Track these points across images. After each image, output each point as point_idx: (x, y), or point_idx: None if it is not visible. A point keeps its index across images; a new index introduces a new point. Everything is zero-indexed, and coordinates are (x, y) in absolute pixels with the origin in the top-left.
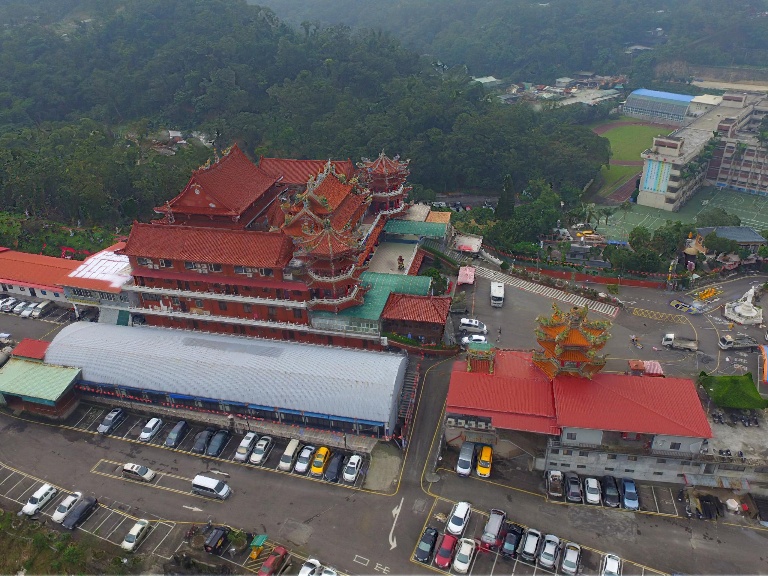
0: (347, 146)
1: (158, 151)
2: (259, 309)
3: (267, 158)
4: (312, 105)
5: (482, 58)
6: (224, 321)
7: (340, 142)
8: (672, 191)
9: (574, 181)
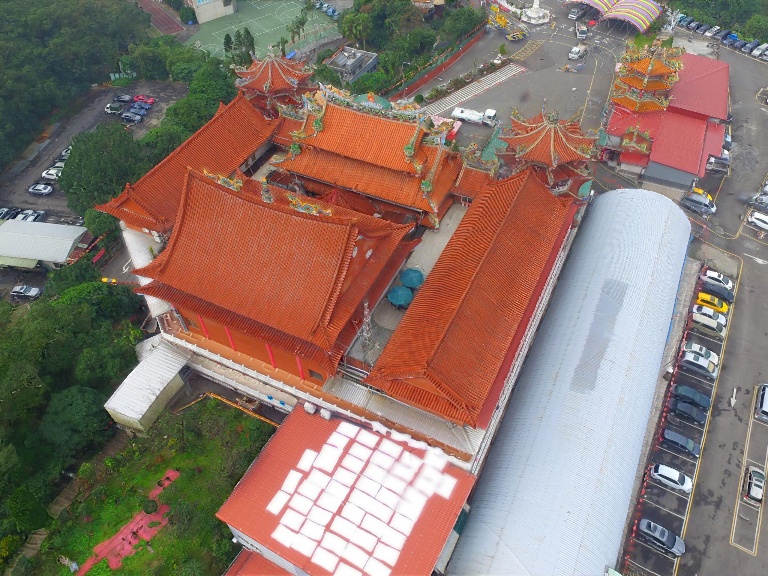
0: None
1: None
2: None
3: (137, 183)
4: None
5: None
6: None
7: None
8: None
9: None
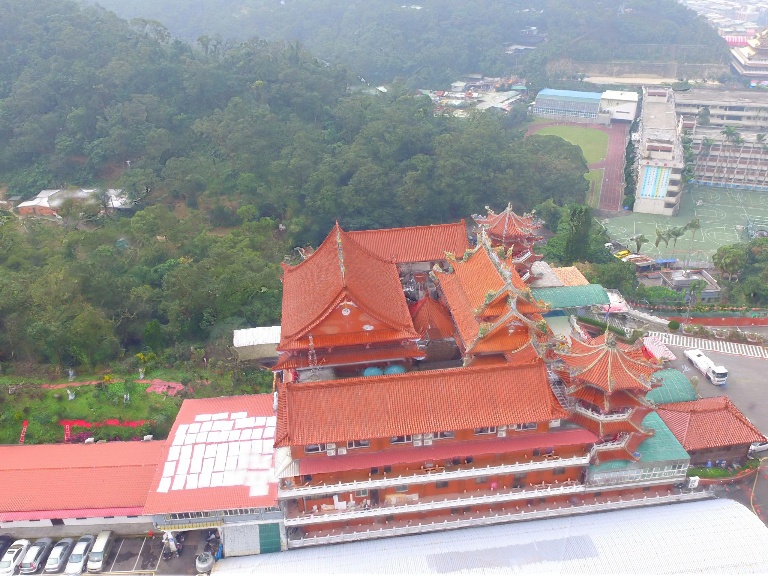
0: (329, 187)
1: (54, 221)
2: (501, 475)
3: None
4: (261, 140)
5: (370, 66)
6: (451, 506)
7: (316, 183)
8: (671, 195)
9: (573, 196)
